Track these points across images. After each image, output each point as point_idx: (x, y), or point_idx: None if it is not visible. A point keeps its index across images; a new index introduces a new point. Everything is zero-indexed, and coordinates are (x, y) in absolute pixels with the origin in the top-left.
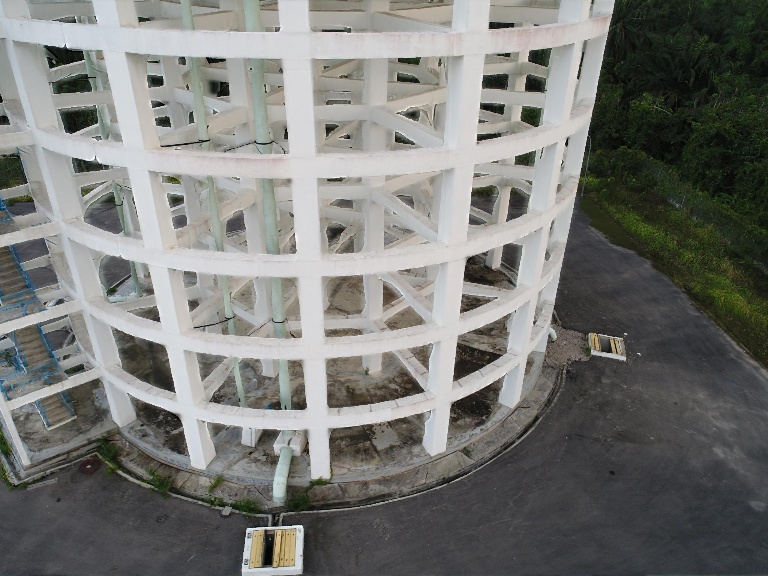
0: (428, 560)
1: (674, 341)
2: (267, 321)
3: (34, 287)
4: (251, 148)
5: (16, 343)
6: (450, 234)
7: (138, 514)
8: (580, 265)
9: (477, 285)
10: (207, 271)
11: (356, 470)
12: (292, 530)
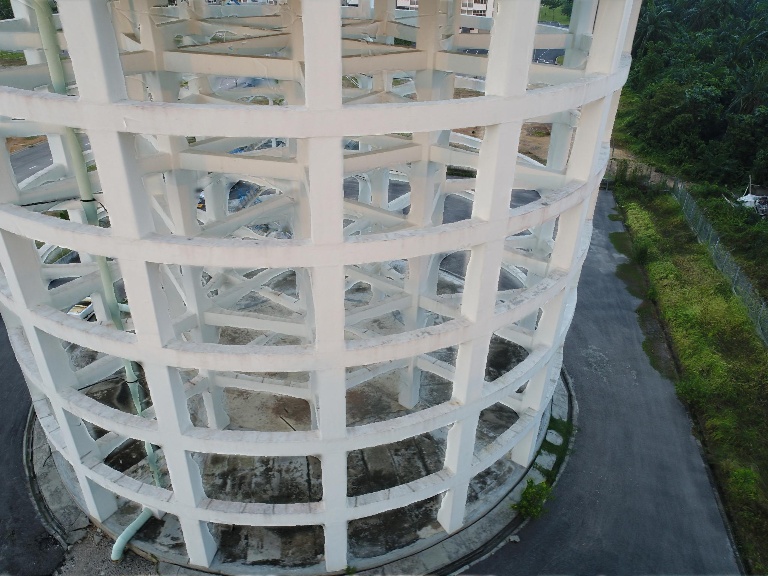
0: (4, 362)
1: None
2: None
3: None
4: None
5: None
6: None
7: None
8: None
9: None
10: None
11: None
12: (81, 311)
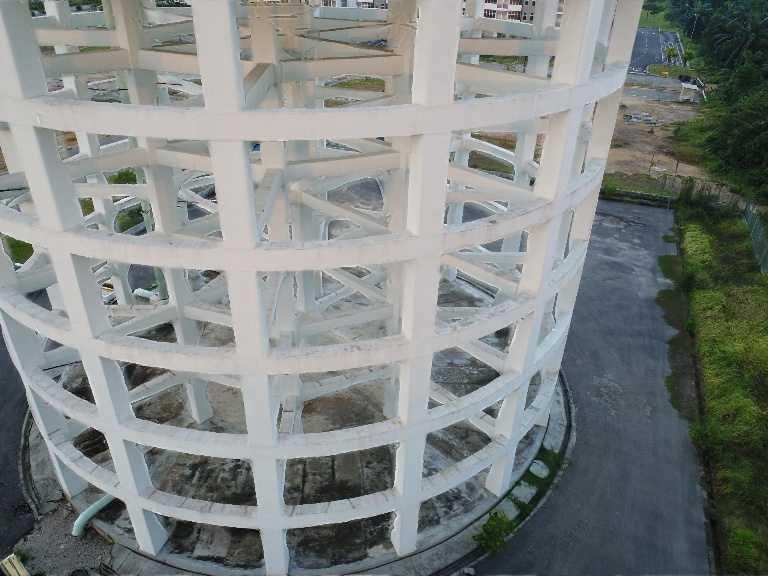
0: None
1: None
2: None
3: None
4: None
5: None
6: None
7: None
8: None
9: (144, 386)
10: None
11: None
12: None
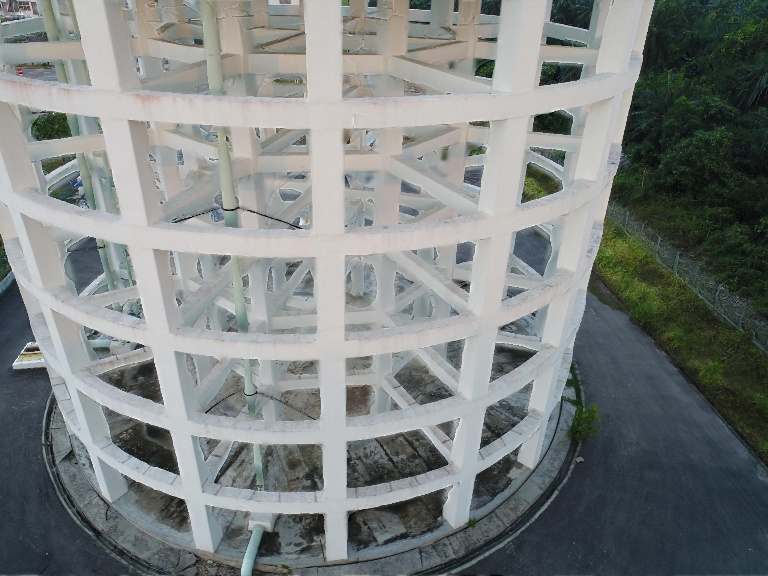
0: None
1: None
2: None
3: (371, 224)
4: None
5: None
6: None
7: None
8: None
9: (244, 413)
10: None
11: None
12: None
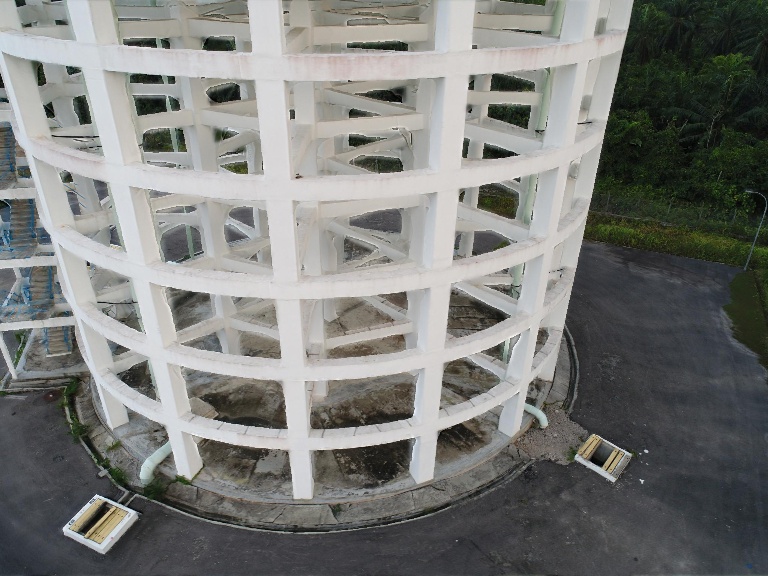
0: None
1: (708, 483)
2: (222, 316)
3: None
4: (199, 150)
5: (30, 280)
6: (274, 270)
7: (48, 447)
8: (662, 352)
9: (452, 338)
10: (75, 253)
11: (218, 482)
12: (124, 512)
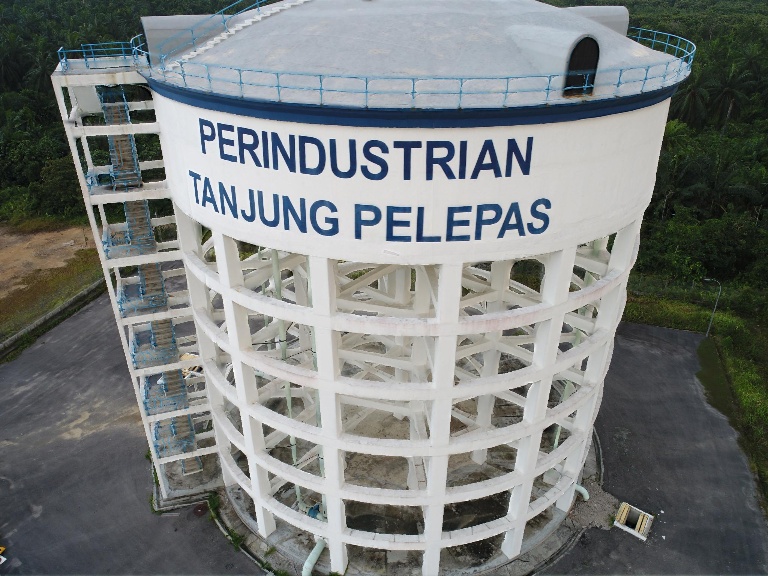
0: None
1: (709, 533)
2: None
3: None
4: None
5: None
6: (434, 439)
7: (217, 557)
8: (658, 422)
9: None
10: None
11: (364, 574)
12: None
